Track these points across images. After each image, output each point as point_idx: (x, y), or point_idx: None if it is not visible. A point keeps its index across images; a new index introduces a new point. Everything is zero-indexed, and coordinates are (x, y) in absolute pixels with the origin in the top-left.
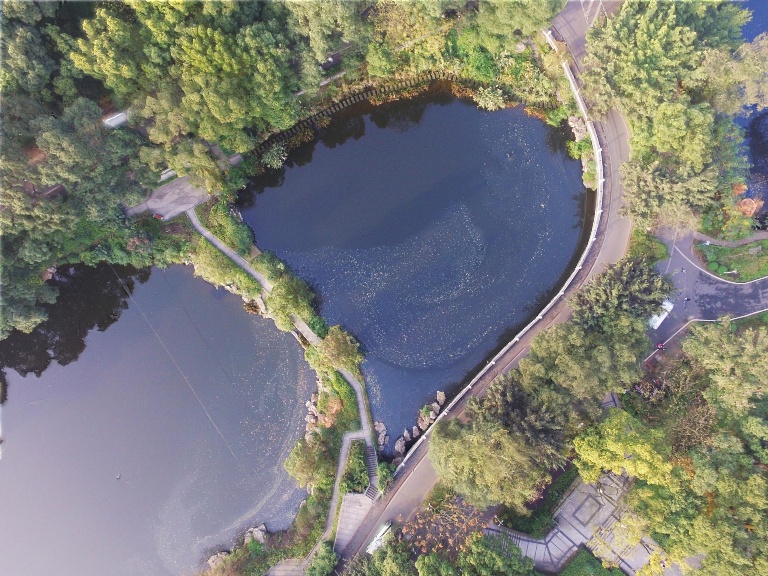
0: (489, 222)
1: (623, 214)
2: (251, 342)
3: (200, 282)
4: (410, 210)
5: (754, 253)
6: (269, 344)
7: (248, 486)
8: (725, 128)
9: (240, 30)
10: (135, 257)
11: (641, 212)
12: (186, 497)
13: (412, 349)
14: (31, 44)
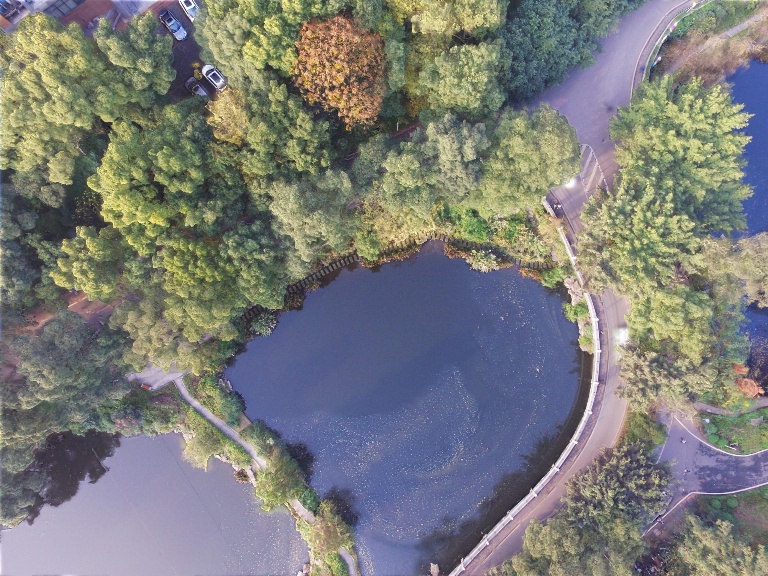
0: (483, 388)
1: (620, 396)
2: (242, 511)
3: None
4: (402, 376)
5: (756, 424)
6: (260, 513)
7: None
8: (726, 307)
9: (223, 238)
10: None
11: (638, 400)
12: None
13: (405, 520)
14: (10, 259)
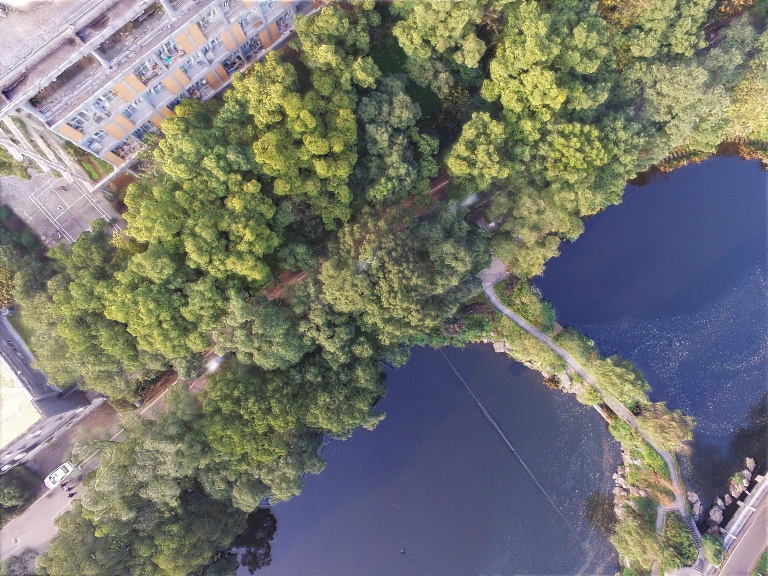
0: None
1: None
2: (552, 417)
3: (497, 359)
4: (706, 277)
5: None
6: (572, 418)
7: (562, 561)
8: None
9: (606, 123)
10: (437, 339)
11: None
12: (502, 575)
13: (719, 417)
14: (404, 150)
